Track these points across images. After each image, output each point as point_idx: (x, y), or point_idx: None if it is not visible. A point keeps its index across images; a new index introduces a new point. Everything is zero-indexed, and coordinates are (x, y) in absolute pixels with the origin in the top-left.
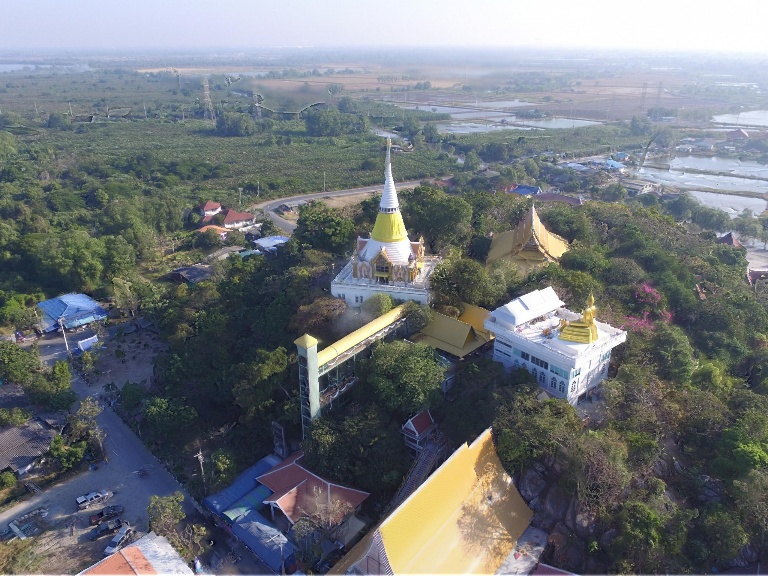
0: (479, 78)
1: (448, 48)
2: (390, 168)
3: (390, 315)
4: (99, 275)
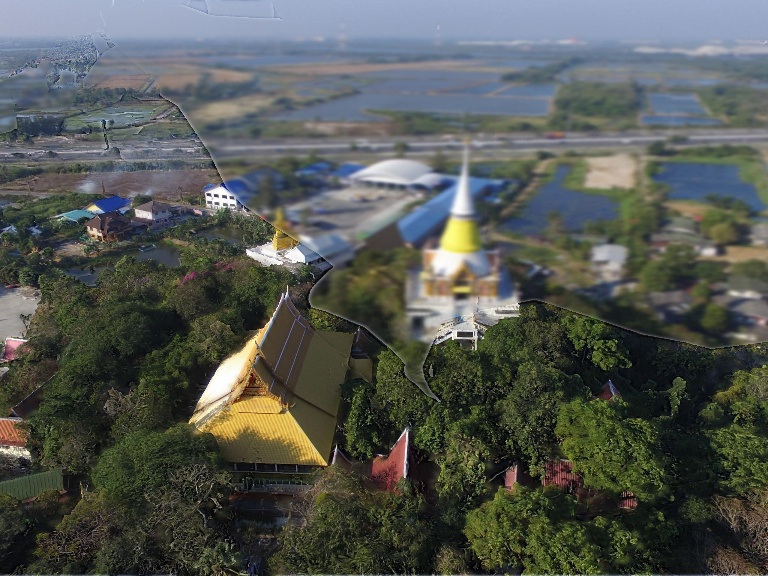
0: (401, 229)
1: (665, 58)
2: None
3: None
4: None
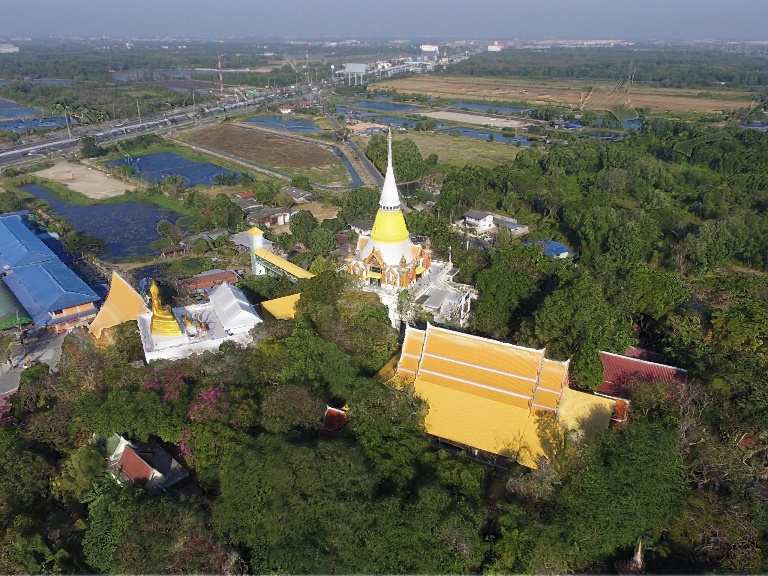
0: None
1: None
2: (389, 163)
3: (306, 273)
4: (598, 246)
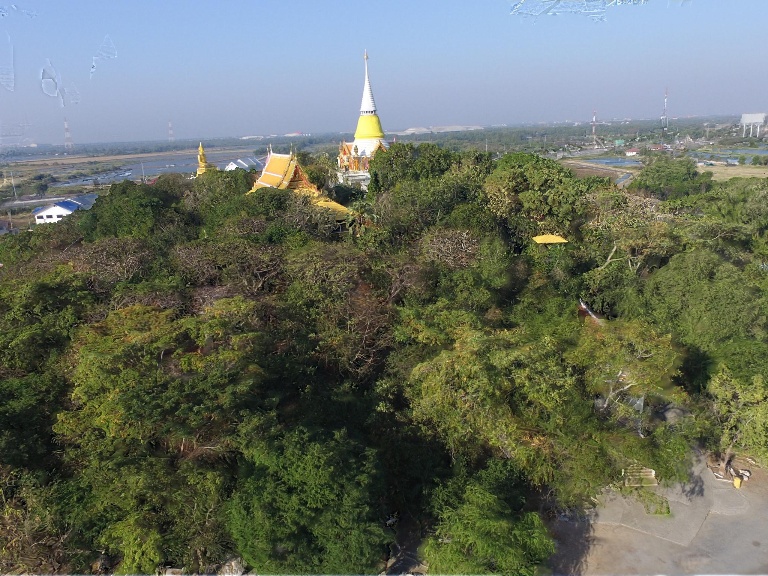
0: None
1: None
2: (366, 78)
3: None
4: None
